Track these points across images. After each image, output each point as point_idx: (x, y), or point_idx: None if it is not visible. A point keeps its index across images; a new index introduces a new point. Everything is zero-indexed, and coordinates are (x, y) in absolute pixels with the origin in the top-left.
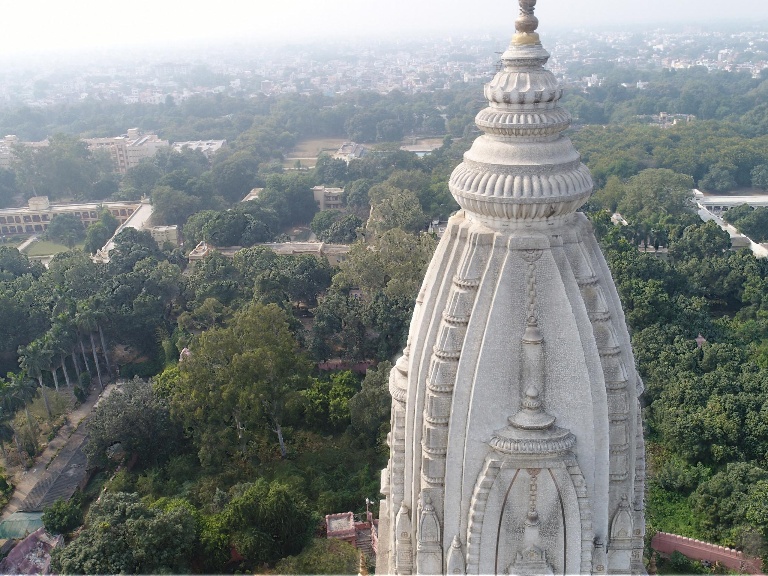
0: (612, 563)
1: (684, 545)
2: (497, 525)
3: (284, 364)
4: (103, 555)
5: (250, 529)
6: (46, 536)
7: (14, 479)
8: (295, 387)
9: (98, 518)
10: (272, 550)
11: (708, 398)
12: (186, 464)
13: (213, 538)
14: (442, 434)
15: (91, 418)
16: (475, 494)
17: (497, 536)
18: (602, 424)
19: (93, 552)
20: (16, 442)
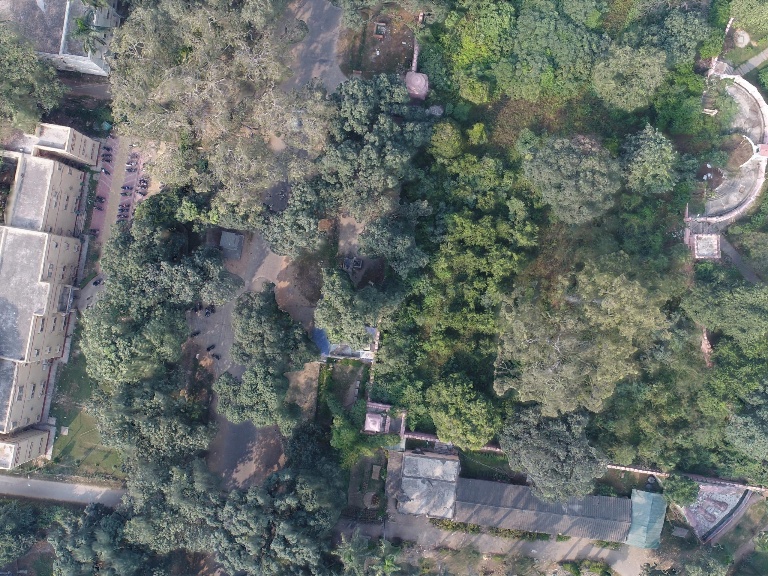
0: None
1: None
2: None
3: None
4: None
5: None
6: None
7: (545, 568)
8: None
9: None
10: None
11: None
12: None
13: None
14: None
15: None
16: None
17: None
18: None
19: None
20: None
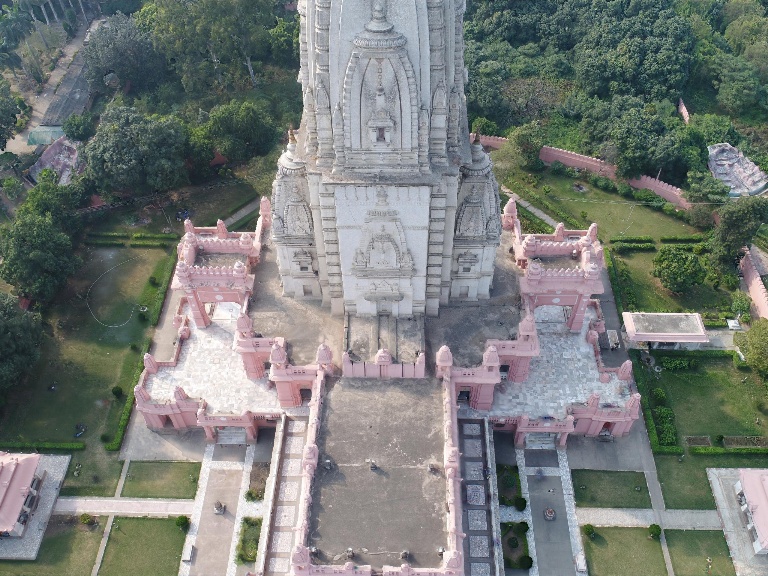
0: (435, 123)
1: (564, 156)
2: (359, 95)
3: (248, 1)
4: (117, 149)
5: (227, 136)
6: (68, 142)
7: (29, 102)
8: (260, 24)
9: (108, 124)
10: (246, 153)
11: (620, 41)
12: (172, 90)
13: (199, 142)
14: (326, 36)
15: (85, 49)
16: (346, 75)
17: (360, 102)
18: (424, 31)
19: (109, 147)
20: (24, 69)
